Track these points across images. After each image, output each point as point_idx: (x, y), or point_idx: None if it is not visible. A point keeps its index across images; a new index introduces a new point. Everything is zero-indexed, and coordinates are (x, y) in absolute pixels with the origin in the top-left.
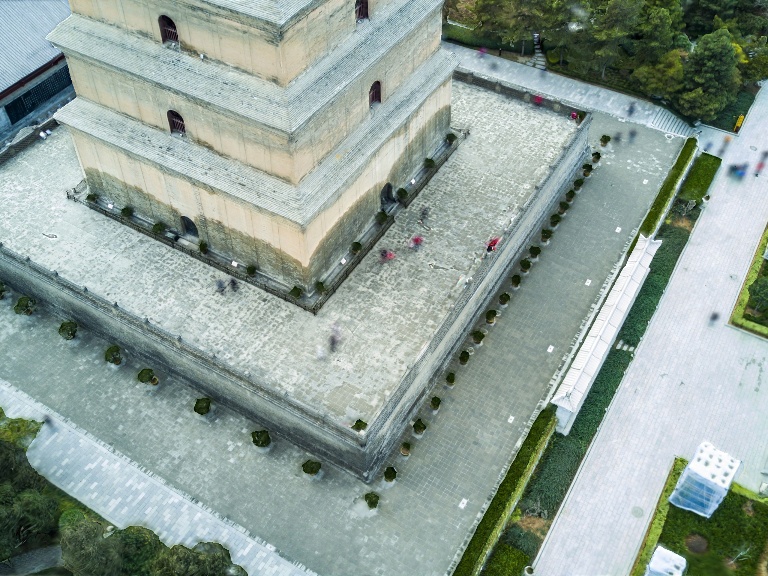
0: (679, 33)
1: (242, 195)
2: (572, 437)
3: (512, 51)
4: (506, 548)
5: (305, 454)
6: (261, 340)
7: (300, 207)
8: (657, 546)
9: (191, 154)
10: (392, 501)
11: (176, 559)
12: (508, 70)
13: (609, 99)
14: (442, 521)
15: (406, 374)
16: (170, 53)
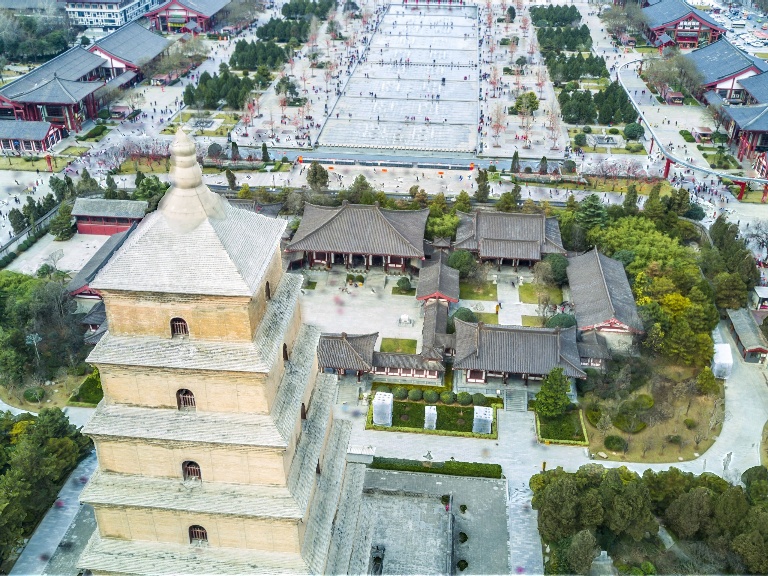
0: (8, 449)
1: (371, 539)
2: (376, 462)
3: (1, 566)
4: (448, 468)
5: (456, 549)
6: (417, 568)
7: (371, 503)
8: (414, 427)
9: (354, 575)
10: (456, 507)
11: (570, 481)
12: (32, 562)
13: (72, 493)
14: (453, 488)
15: (406, 490)
16: (335, 535)
